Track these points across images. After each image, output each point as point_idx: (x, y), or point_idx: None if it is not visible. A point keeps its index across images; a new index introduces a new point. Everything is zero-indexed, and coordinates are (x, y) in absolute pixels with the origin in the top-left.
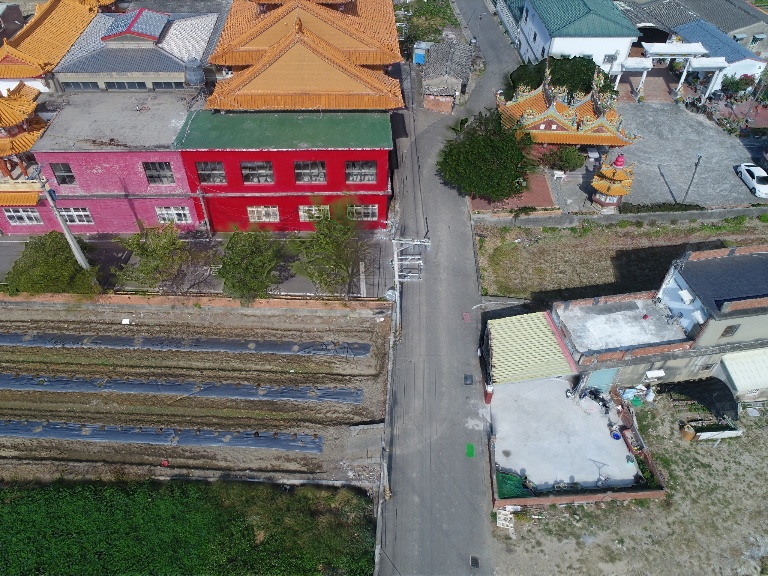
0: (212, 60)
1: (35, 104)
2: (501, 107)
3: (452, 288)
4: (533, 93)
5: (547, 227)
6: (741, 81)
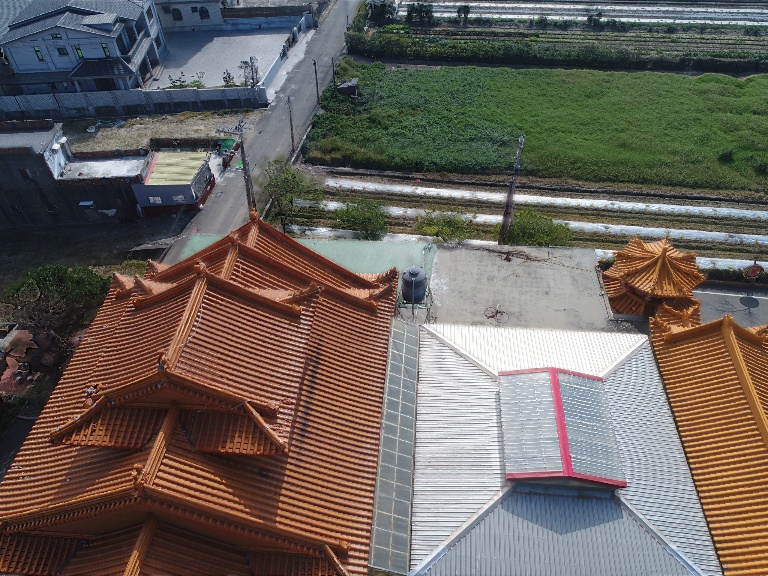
0: None
1: (620, 274)
2: None
3: None
4: None
5: None
6: None
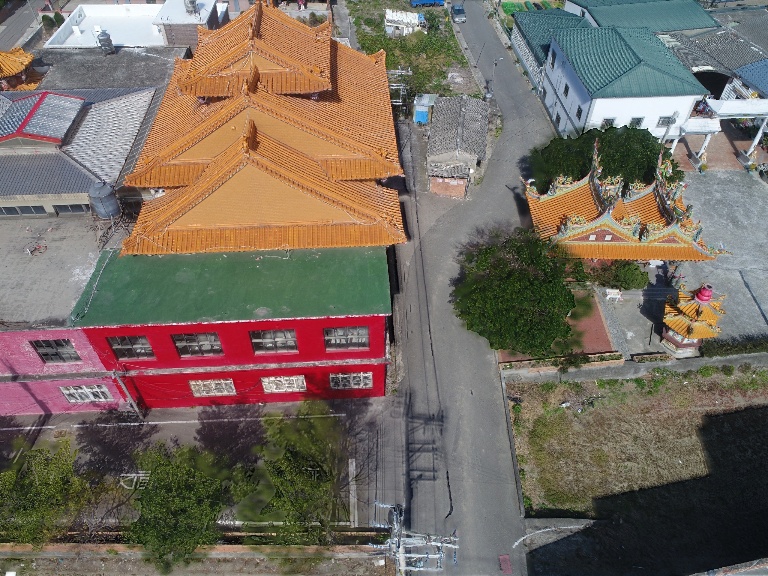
0: (130, 181)
1: None
2: (532, 201)
3: (481, 507)
4: (576, 185)
5: (604, 379)
6: None
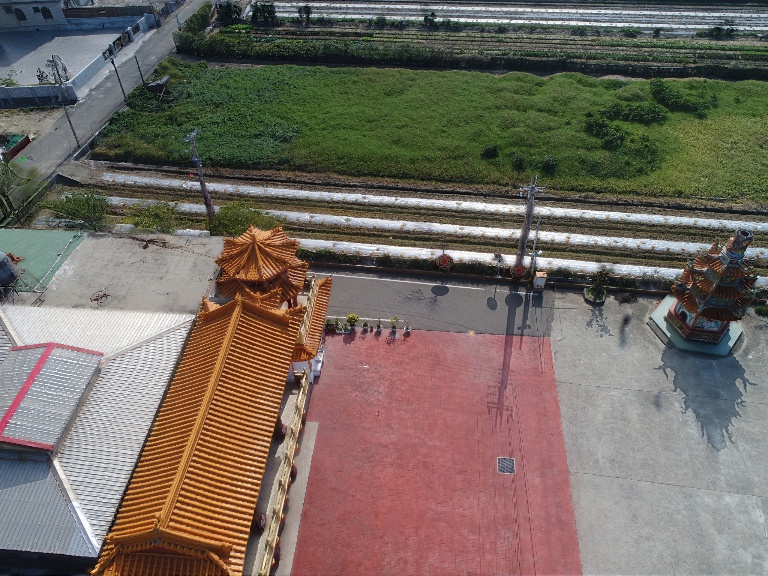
0: None
1: None
2: None
3: None
4: None
5: None
6: None
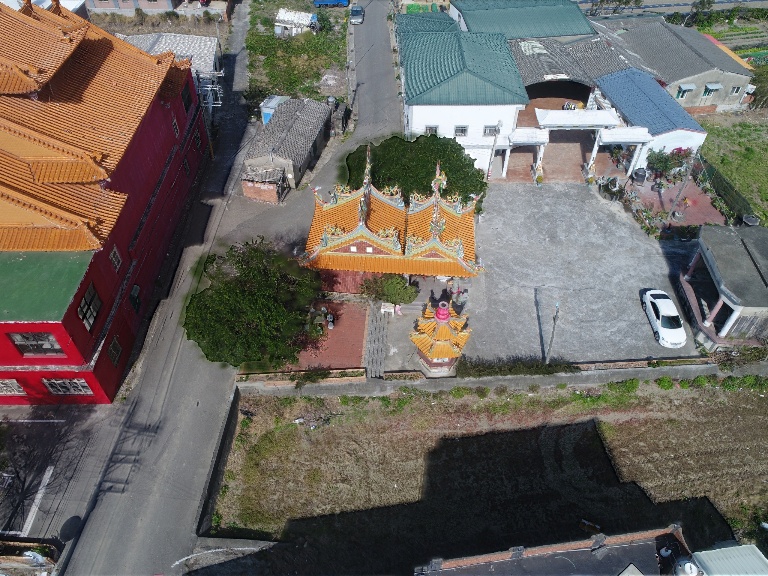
0: None
1: None
2: (318, 209)
3: (157, 523)
4: (355, 194)
5: (349, 396)
6: (672, 157)
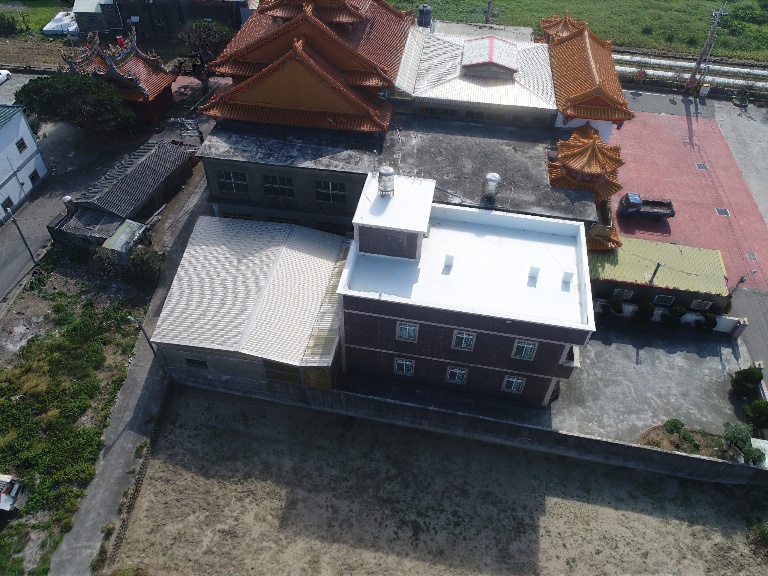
0: None
1: None
2: (151, 96)
3: None
4: None
5: None
6: None
